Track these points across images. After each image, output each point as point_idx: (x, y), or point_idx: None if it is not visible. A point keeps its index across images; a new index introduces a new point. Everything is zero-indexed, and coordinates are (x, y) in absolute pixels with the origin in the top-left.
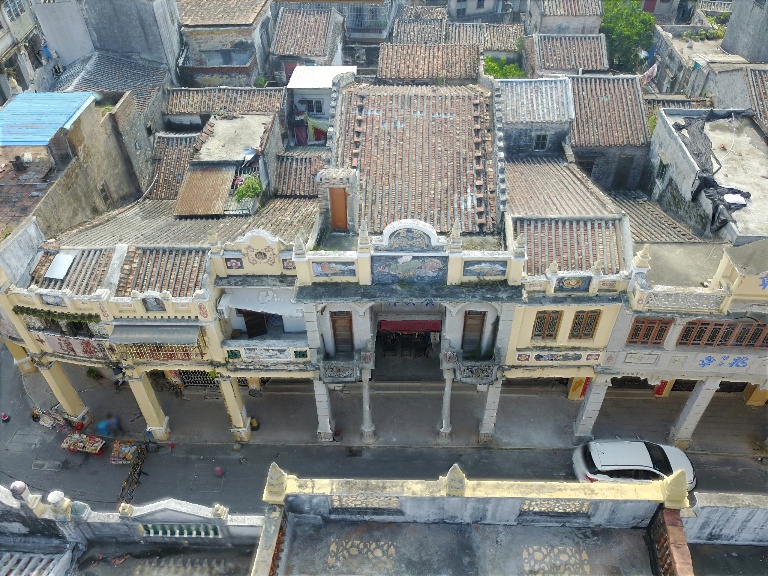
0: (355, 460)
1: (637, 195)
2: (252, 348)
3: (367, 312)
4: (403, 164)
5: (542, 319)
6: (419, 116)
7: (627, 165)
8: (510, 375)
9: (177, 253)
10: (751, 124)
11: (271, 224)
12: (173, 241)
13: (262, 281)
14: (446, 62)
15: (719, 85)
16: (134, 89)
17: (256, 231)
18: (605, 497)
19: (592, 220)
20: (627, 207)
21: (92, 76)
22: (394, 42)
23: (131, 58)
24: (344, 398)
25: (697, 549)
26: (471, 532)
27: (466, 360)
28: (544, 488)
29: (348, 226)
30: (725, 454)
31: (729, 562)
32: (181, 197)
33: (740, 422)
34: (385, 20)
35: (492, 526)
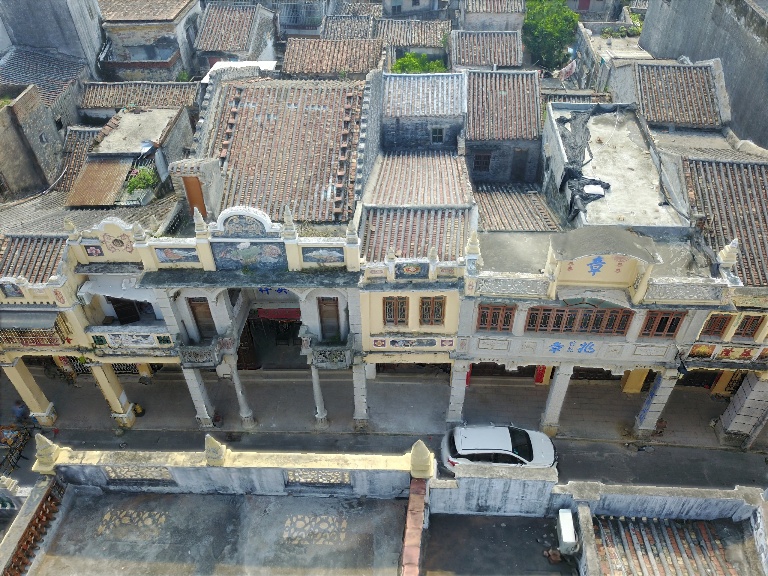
0: (233, 445)
1: (532, 188)
2: (116, 334)
3: (222, 298)
4: (271, 155)
5: (391, 305)
6: (293, 108)
7: (522, 158)
8: (370, 361)
9: (45, 241)
10: (634, 118)
11: (155, 214)
12: (47, 230)
13: (122, 268)
14: (350, 57)
15: (617, 80)
16: (46, 83)
17: (109, 219)
18: (356, 467)
19: (443, 209)
20: (514, 199)
21: (4, 70)
22: (321, 38)
23: (49, 53)
24: (232, 385)
25: (469, 520)
26: (243, 502)
27: (326, 346)
28: (301, 459)
29: (208, 215)
30: (594, 440)
31: (495, 532)
32: (75, 188)
33: (614, 409)
34: (319, 17)
35: (264, 497)
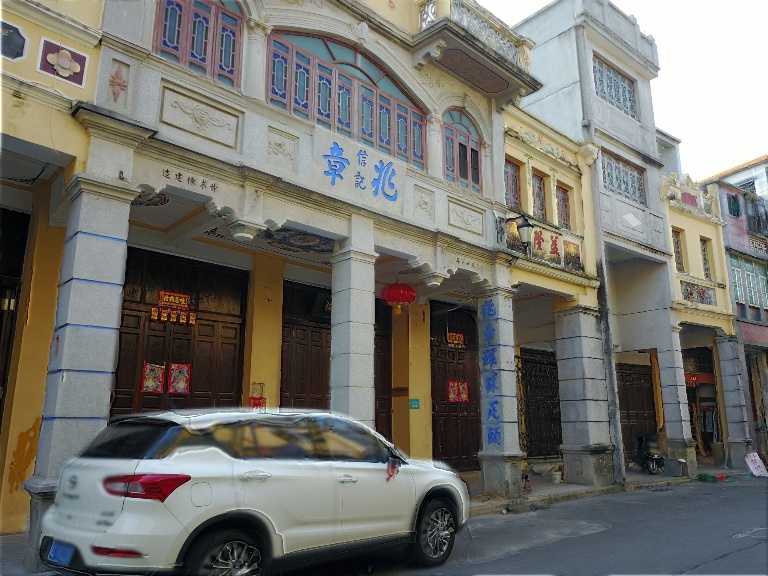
0: None
1: None
2: None
3: None
4: None
5: None
6: None
7: None
8: None
9: None
10: None
11: None
12: None
13: None
14: None
15: None
16: None
17: None
18: None
19: None
20: None
21: None
22: None
23: None
24: None
25: None
26: None
27: None
28: None
29: None
30: None
31: None
32: None
33: None
34: None
35: None
